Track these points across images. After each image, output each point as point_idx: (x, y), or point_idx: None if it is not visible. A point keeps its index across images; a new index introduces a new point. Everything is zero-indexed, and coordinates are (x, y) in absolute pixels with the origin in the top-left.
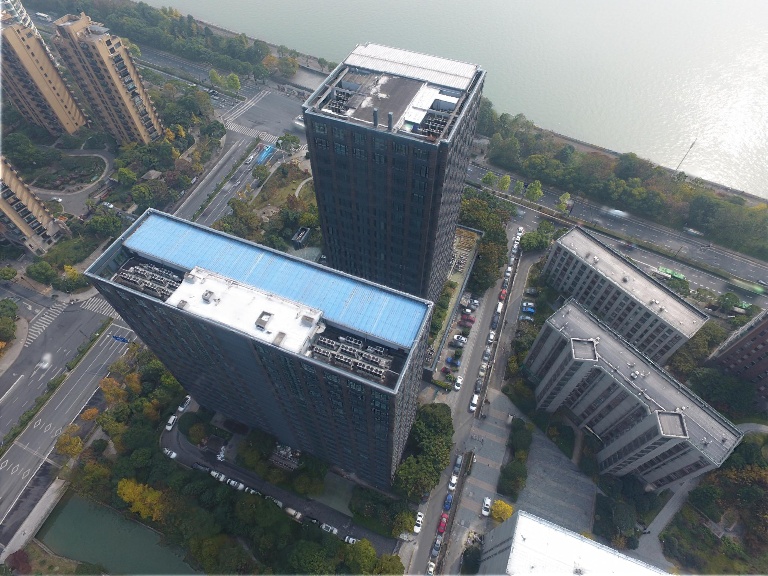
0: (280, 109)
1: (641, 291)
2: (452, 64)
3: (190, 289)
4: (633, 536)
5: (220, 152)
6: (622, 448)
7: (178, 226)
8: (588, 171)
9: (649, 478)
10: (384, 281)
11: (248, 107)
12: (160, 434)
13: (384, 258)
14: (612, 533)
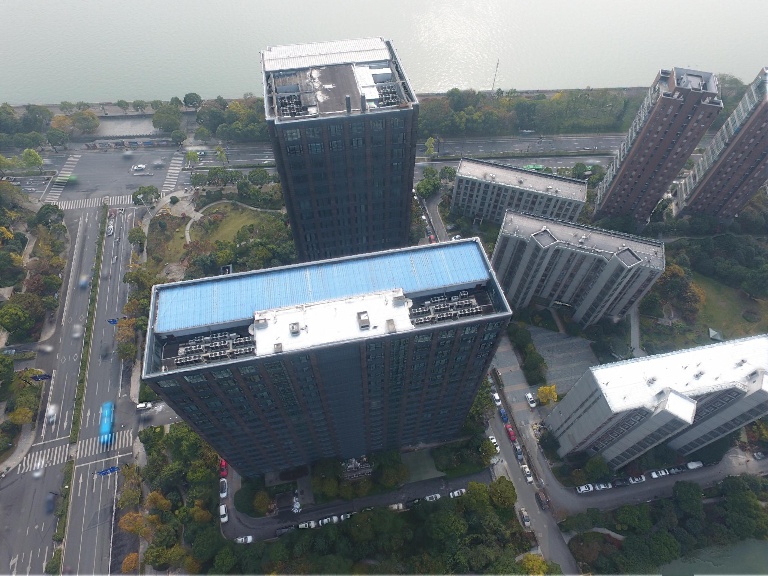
0: (106, 167)
1: (536, 185)
2: (360, 42)
3: (269, 333)
4: (631, 355)
5: (68, 237)
6: (595, 298)
7: (200, 288)
8: (434, 114)
9: (615, 312)
10: None
11: (65, 179)
12: (219, 531)
13: (366, 240)
14: None
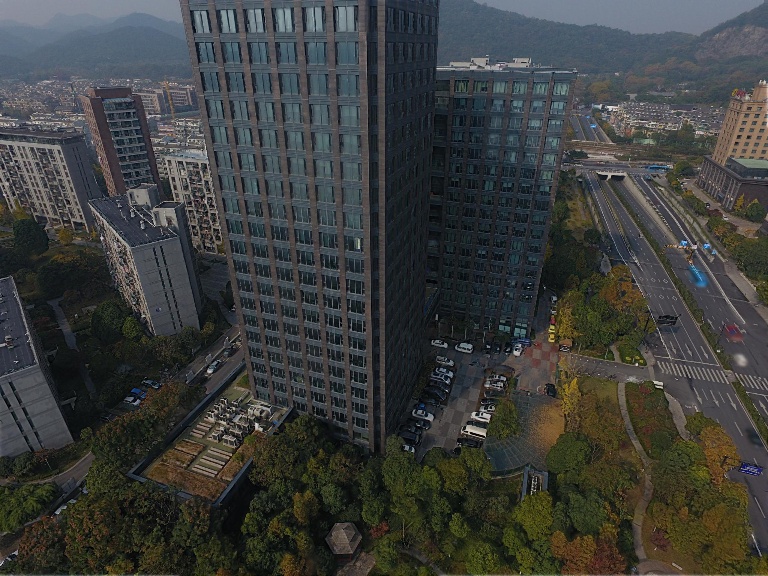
0: None
1: None
2: None
3: None
4: None
5: None
6: None
7: None
8: None
9: None
10: None
11: None
12: None
13: None
14: None
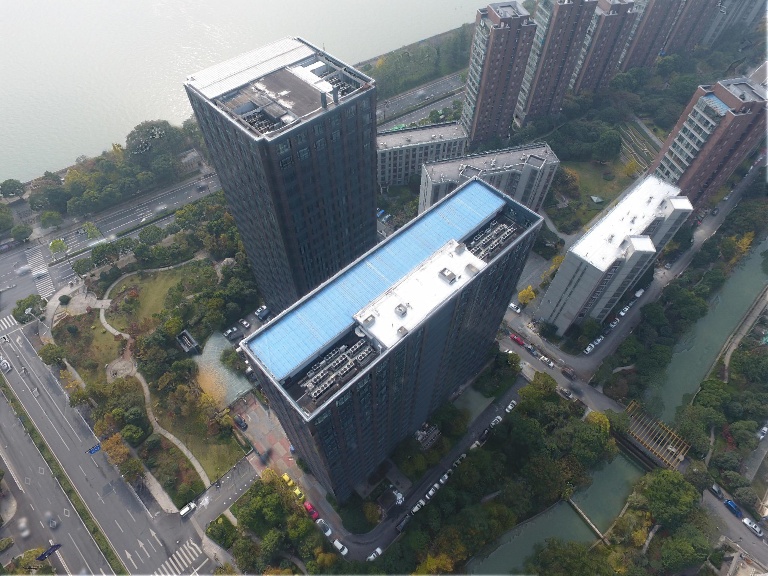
0: None
1: (421, 138)
2: (274, 47)
3: (381, 326)
4: (560, 238)
5: None
6: None
7: (285, 323)
8: None
9: None
10: (350, 255)
11: None
12: None
13: (348, 232)
14: (553, 250)
